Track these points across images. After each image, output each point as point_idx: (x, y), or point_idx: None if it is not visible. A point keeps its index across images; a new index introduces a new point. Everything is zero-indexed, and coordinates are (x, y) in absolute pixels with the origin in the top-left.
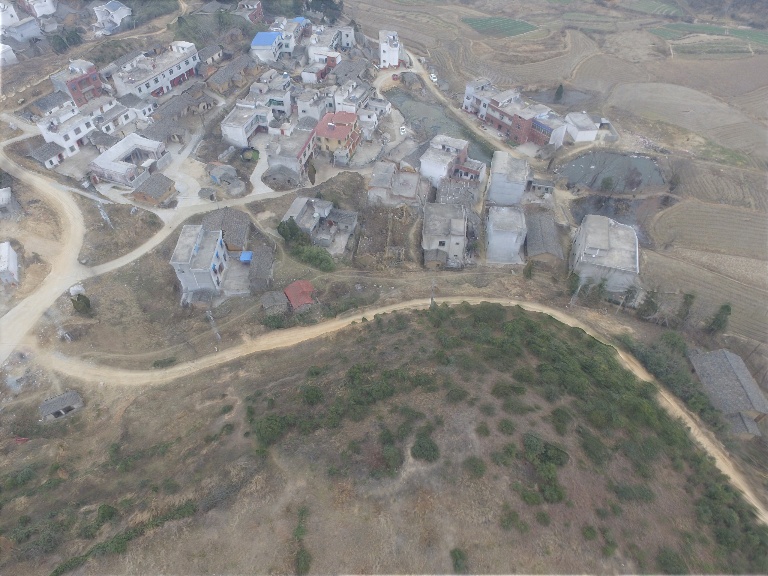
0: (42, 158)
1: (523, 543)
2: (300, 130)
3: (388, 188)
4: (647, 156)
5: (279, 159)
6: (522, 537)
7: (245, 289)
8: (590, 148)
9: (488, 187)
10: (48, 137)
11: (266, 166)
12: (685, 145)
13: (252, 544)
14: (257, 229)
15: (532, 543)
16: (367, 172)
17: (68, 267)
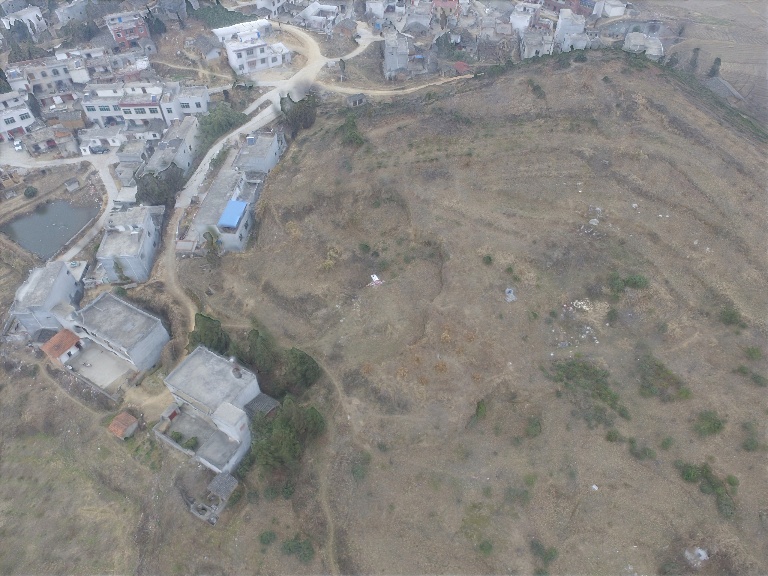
0: (261, 15)
1: (632, 76)
2: (423, 3)
3: (495, 28)
4: (661, 22)
5: (415, 17)
6: (631, 75)
7: (425, 70)
8: (621, 19)
9: (558, 31)
10: (261, 4)
11: (400, 28)
12: (687, 16)
13: (508, 92)
14: (417, 48)
15: (636, 76)
16: (470, 31)
17: (317, 57)
